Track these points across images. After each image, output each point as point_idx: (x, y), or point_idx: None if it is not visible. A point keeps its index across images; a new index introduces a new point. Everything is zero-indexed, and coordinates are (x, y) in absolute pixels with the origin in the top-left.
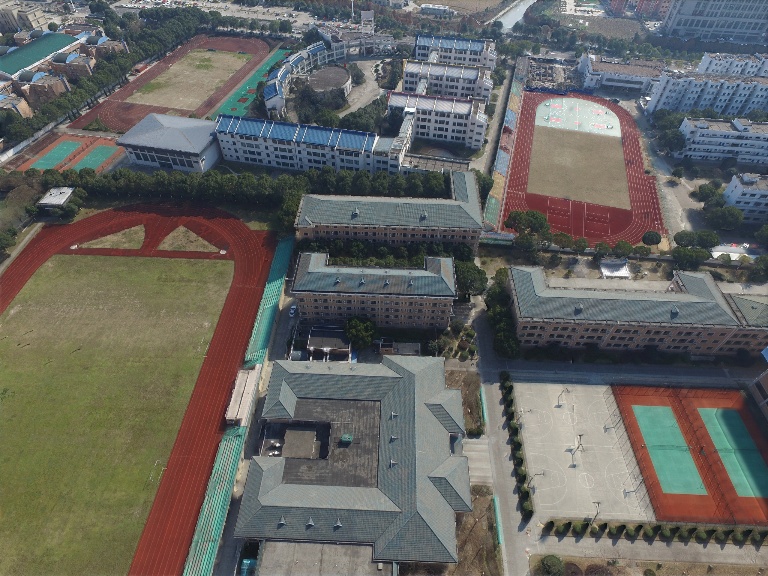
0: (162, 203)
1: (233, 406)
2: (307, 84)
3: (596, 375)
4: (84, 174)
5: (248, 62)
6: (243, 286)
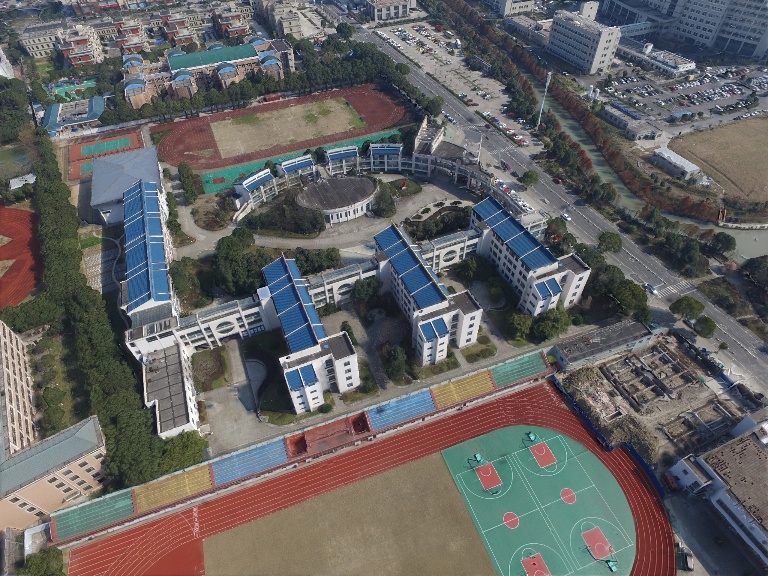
0: None
1: None
2: None
3: None
4: (45, 174)
5: (347, 131)
6: None
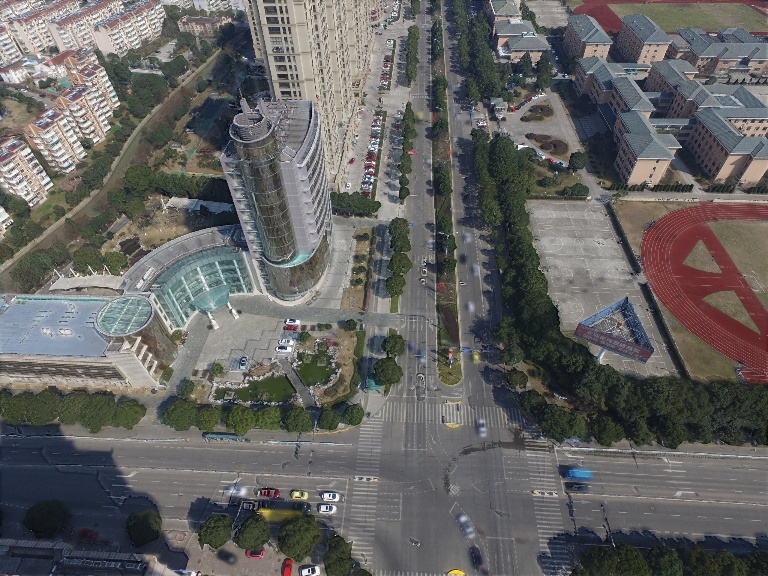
0: None
1: None
2: None
3: None
4: None
5: None
6: None
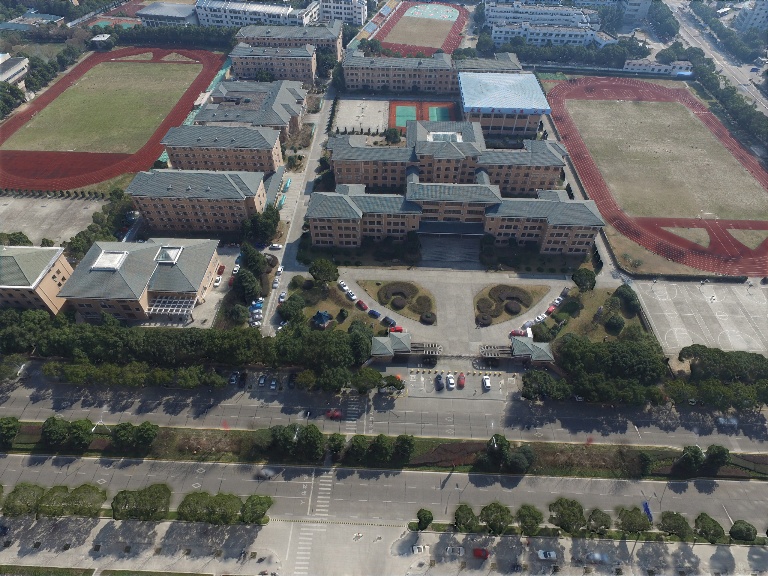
0: (163, 45)
1: (198, 101)
2: None
3: (384, 98)
4: (117, 27)
5: None
6: (207, 72)
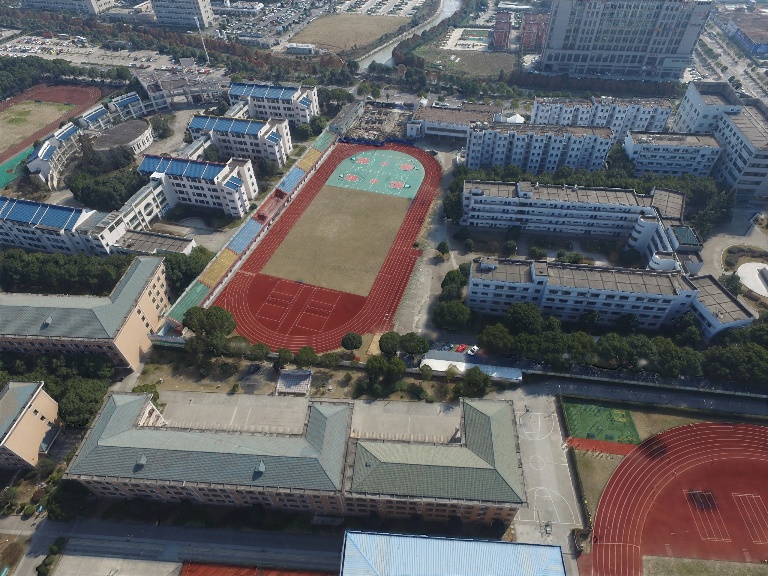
0: None
1: None
2: (88, 142)
3: (175, 545)
4: None
5: (66, 114)
6: None
